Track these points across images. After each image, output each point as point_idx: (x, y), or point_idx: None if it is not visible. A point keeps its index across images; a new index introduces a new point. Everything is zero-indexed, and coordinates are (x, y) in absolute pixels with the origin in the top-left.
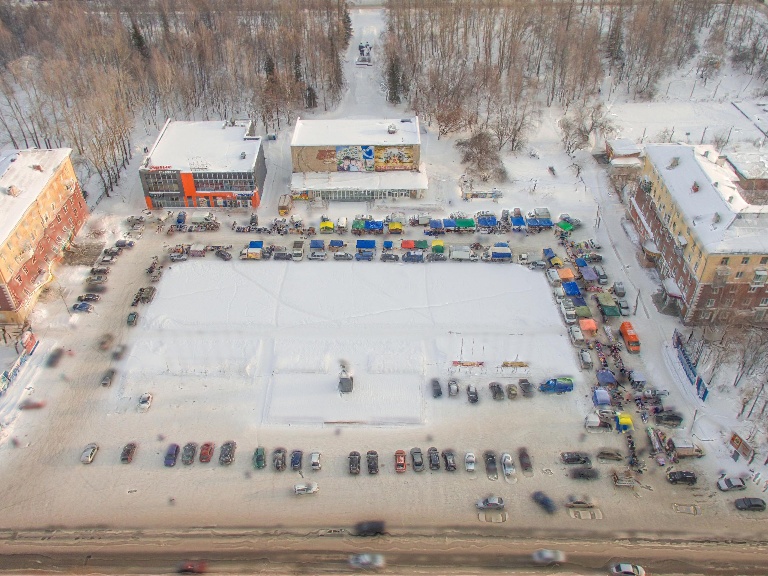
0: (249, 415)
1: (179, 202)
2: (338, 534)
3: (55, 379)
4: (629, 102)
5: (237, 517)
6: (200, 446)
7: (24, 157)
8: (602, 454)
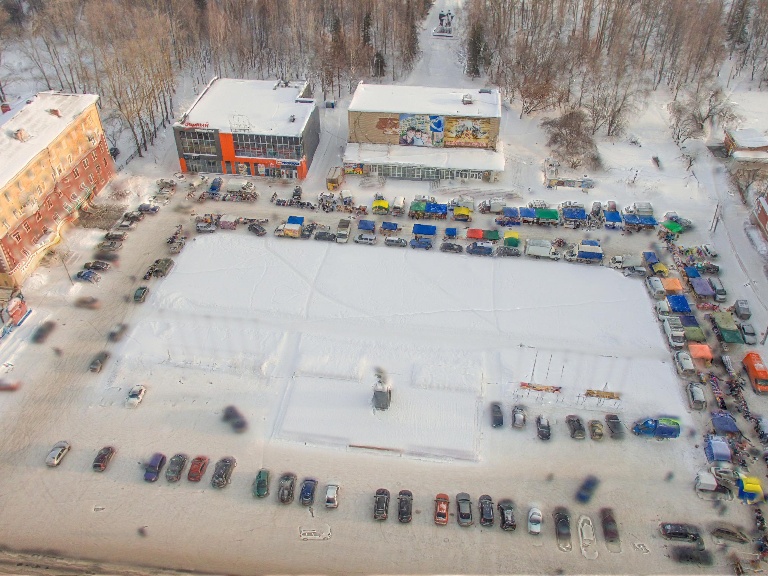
0: (257, 425)
1: (216, 167)
2: None
3: (39, 357)
4: (753, 90)
5: (222, 561)
6: (191, 459)
7: (42, 100)
8: (719, 532)
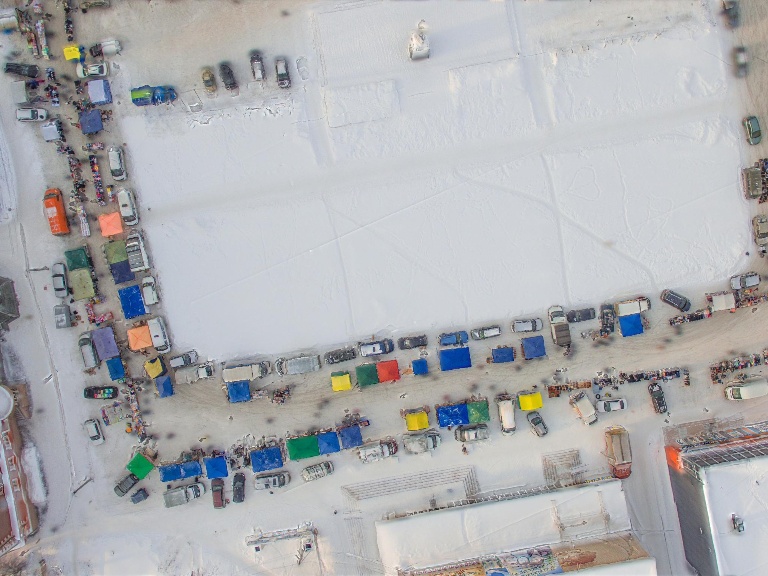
0: None
1: None
2: None
3: None
4: None
5: None
6: None
7: None
8: (103, 2)
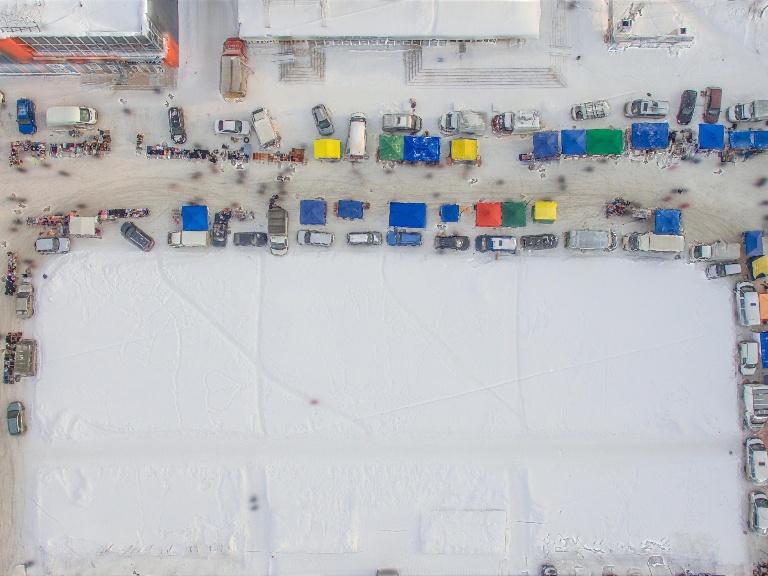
0: None
1: (5, 67)
2: None
3: None
4: None
5: None
6: None
7: None
8: None
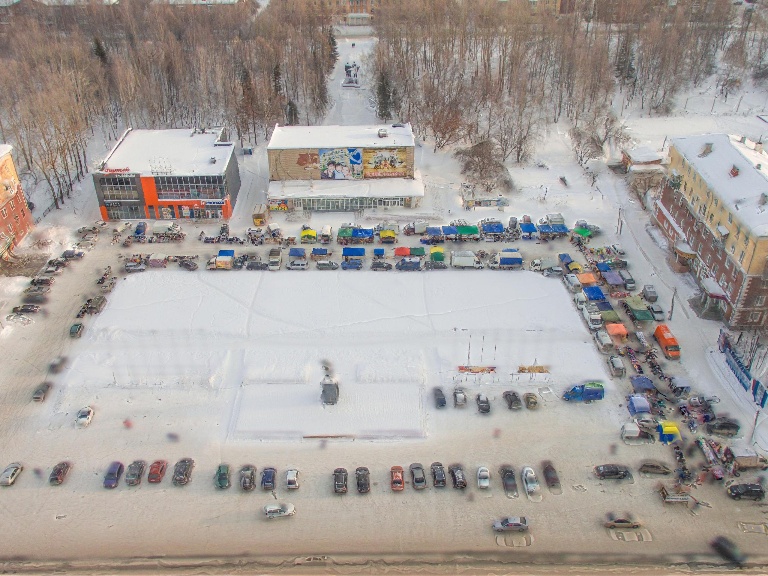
0: (211, 430)
1: (138, 213)
2: (319, 562)
3: None
4: (644, 117)
5: (191, 545)
6: (149, 465)
7: None
8: (645, 467)
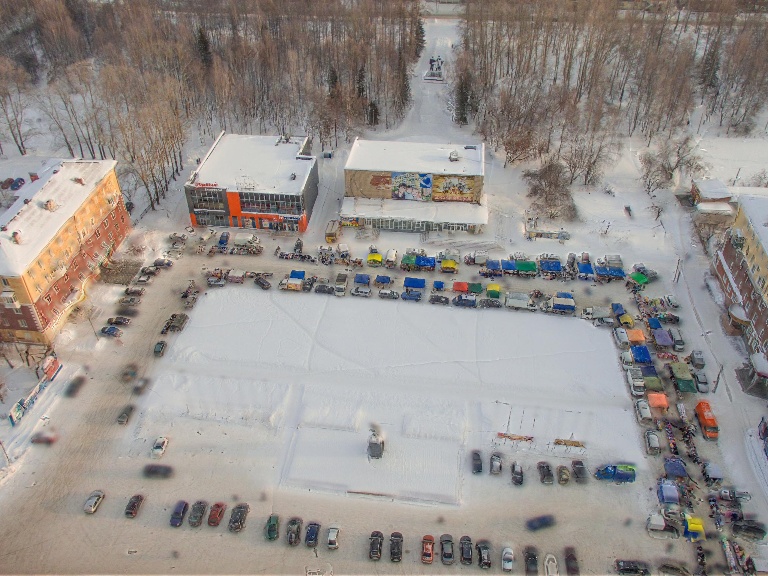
0: (267, 473)
1: (224, 221)
2: None
3: (72, 410)
4: (721, 136)
5: None
6: (210, 505)
7: (67, 169)
8: (665, 568)
